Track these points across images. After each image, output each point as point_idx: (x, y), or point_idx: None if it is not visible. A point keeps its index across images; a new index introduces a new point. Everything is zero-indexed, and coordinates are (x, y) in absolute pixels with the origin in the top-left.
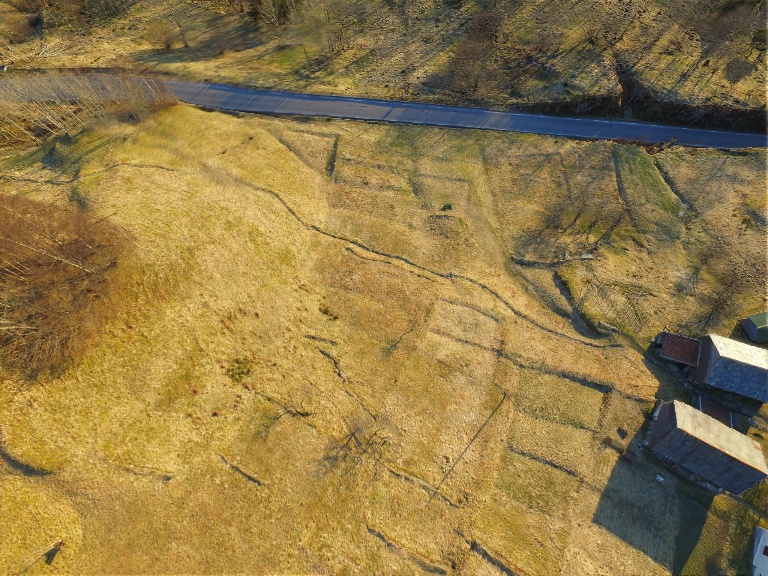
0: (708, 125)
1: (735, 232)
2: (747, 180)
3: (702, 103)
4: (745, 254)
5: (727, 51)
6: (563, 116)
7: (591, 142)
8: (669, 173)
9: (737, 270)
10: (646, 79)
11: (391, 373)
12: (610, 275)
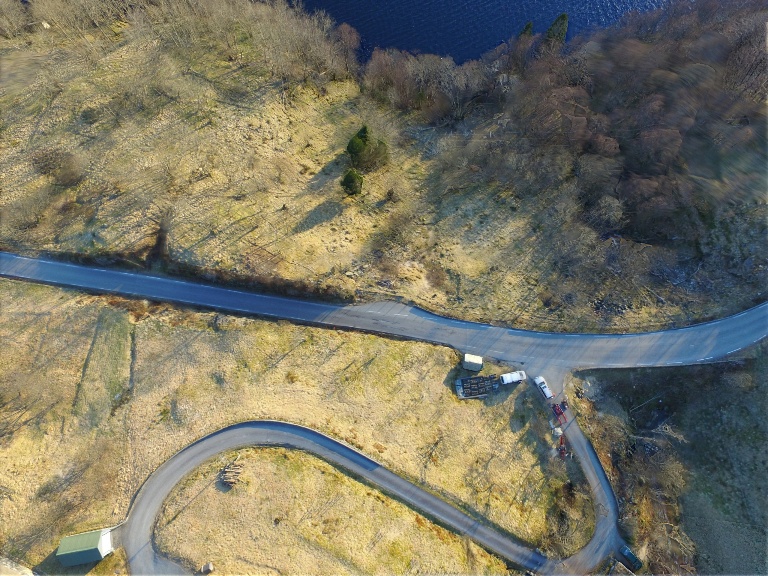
0: (228, 285)
1: (146, 425)
2: (200, 361)
3: (211, 266)
4: (139, 452)
5: (328, 189)
6: (90, 266)
7: (90, 301)
8: (137, 346)
9: (121, 471)
10: (172, 234)
11: None
12: None
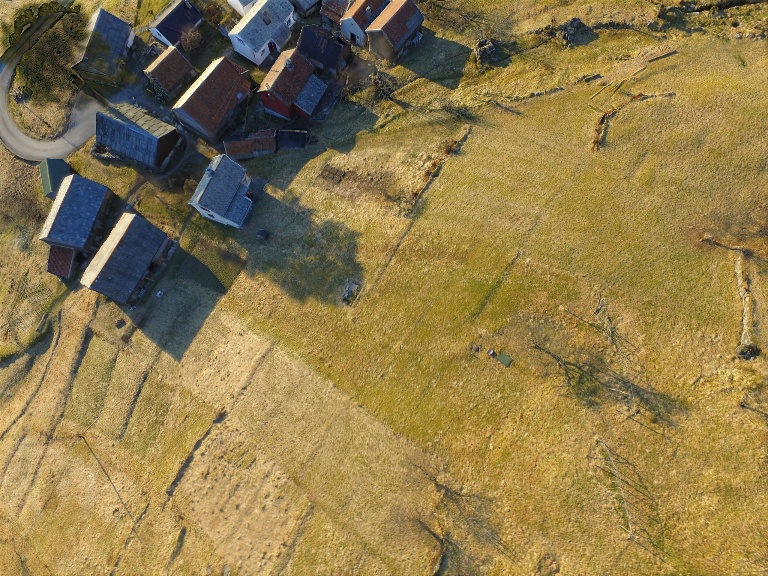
0: None
1: None
2: None
3: None
4: (8, 183)
5: None
6: None
7: None
8: None
9: (21, 192)
10: None
11: (40, 571)
12: (5, 311)
